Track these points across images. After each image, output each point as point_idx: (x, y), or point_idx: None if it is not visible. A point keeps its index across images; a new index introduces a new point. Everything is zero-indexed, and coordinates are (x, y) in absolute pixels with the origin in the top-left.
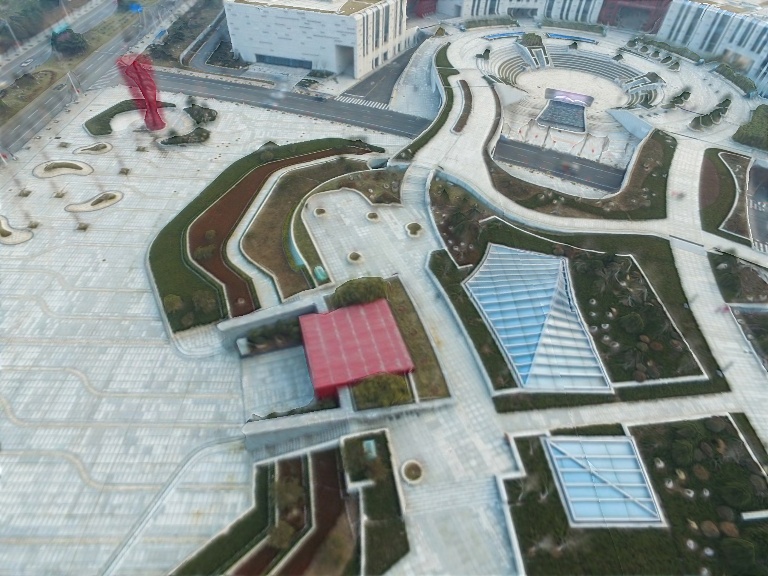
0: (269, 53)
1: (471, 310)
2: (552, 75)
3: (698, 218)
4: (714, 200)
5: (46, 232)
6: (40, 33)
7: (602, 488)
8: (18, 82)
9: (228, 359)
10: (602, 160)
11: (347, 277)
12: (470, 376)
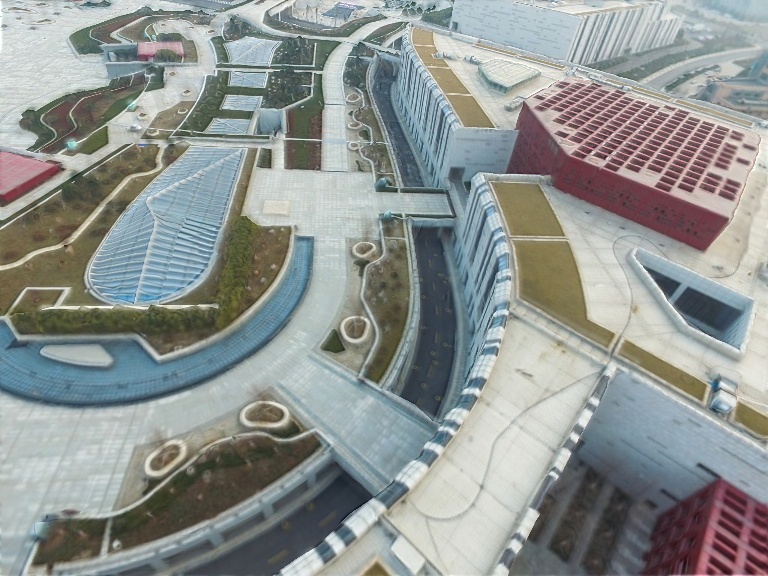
0: None
1: None
2: None
3: None
4: (379, 33)
5: (12, 29)
6: None
7: None
8: None
9: None
10: None
11: None
12: (210, 61)
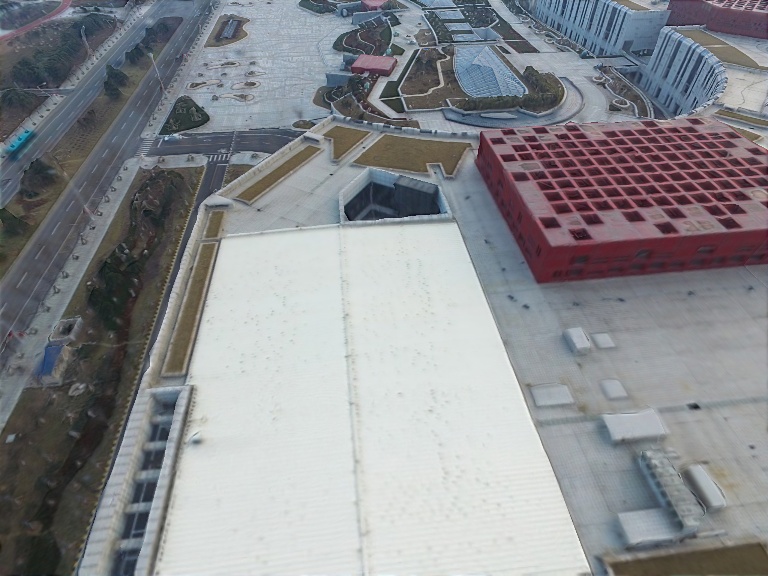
0: None
1: None
2: None
3: None
4: None
5: (257, 4)
6: None
7: None
8: None
9: None
10: None
11: None
12: None
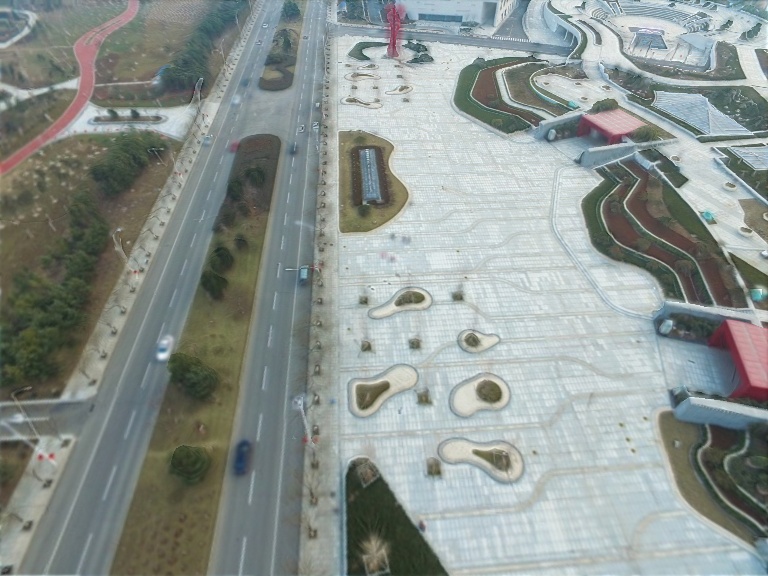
0: (430, 12)
1: (665, 113)
2: (627, 20)
3: (765, 78)
4: None
5: (388, 103)
6: (254, 8)
7: (763, 160)
8: (282, 34)
9: (543, 143)
10: (687, 62)
11: (586, 107)
12: (680, 134)
